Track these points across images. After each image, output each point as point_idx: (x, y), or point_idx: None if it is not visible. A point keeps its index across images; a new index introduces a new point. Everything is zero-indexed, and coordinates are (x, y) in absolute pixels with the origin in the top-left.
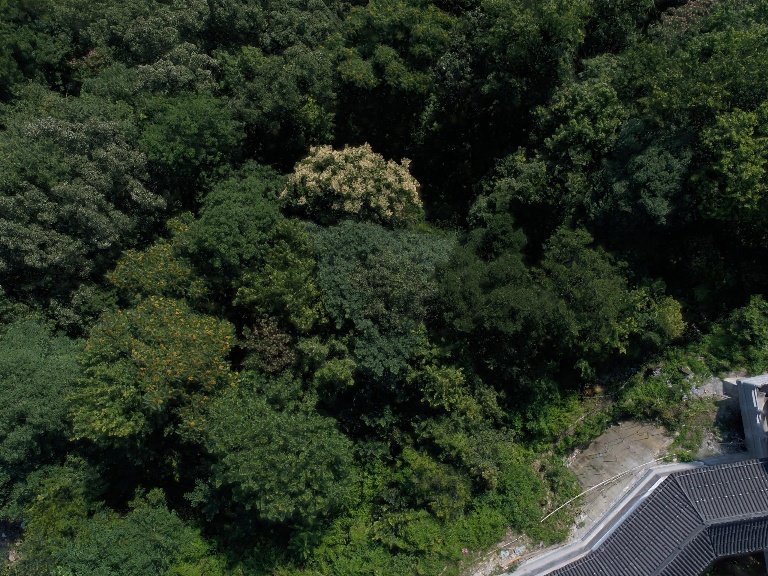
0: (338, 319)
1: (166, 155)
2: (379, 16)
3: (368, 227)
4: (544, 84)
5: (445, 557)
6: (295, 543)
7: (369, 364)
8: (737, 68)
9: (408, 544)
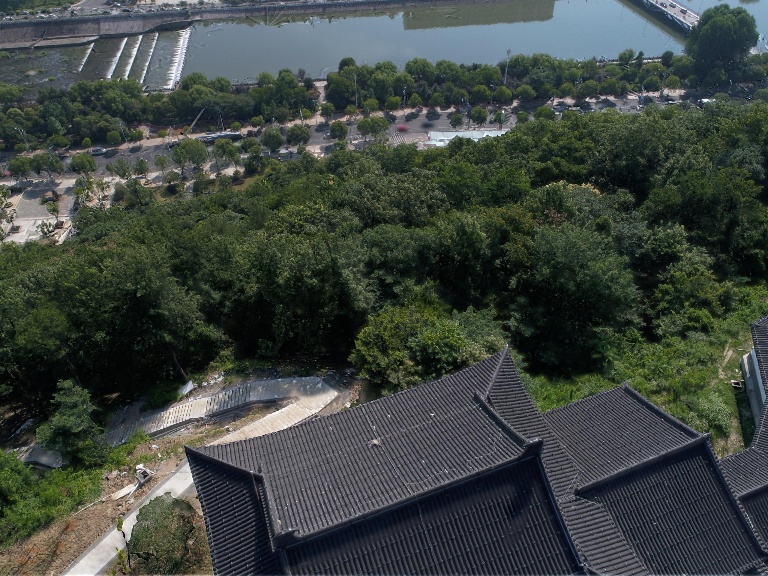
0: (590, 215)
1: (451, 180)
2: (551, 144)
3: (589, 188)
4: (652, 171)
5: (726, 332)
6: (599, 350)
7: (621, 228)
8: (763, 109)
9: (694, 322)
